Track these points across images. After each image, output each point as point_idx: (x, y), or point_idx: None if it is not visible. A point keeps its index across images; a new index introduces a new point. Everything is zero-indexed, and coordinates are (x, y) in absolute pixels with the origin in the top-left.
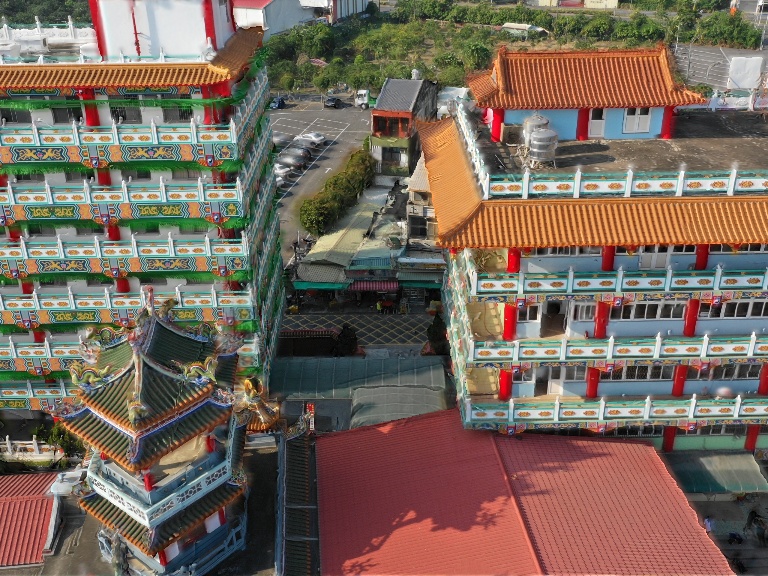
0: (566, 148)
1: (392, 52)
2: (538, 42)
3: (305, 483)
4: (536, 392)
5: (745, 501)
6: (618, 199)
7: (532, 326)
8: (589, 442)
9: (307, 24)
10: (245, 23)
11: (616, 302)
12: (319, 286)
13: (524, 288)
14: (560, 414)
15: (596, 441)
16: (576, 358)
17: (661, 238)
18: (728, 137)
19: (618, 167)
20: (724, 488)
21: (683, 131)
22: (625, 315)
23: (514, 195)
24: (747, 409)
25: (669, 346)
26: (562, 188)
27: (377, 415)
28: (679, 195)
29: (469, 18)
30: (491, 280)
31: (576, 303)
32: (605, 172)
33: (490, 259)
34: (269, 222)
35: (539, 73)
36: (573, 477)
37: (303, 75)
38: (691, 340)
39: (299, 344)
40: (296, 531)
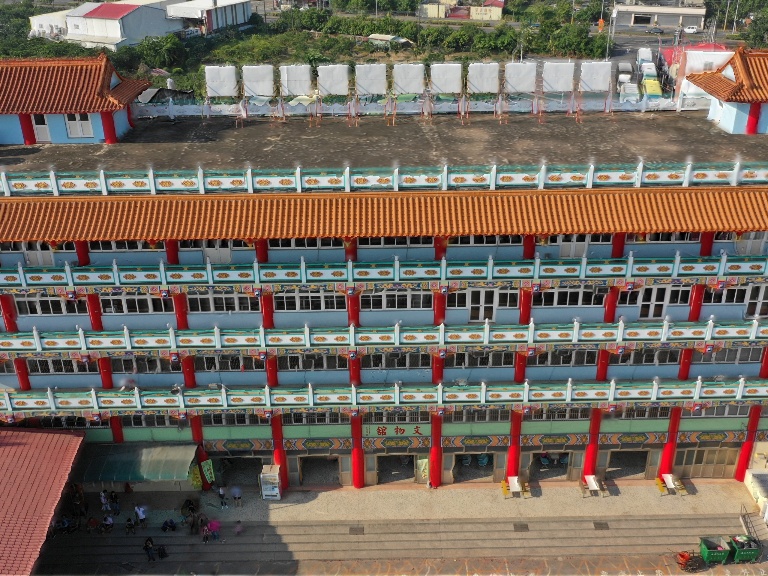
0: None
1: (242, 62)
2: (396, 53)
3: None
4: None
5: (210, 491)
6: None
7: None
8: (15, 432)
9: (175, 34)
10: (105, 33)
11: None
12: None
13: None
14: None
15: (24, 431)
16: None
17: None
18: (172, 142)
19: (10, 169)
20: (143, 477)
21: (142, 136)
22: (32, 310)
23: None
24: (148, 400)
25: (49, 339)
26: None
27: None
28: (7, 195)
29: (343, 29)
30: None
31: None
32: None
33: None
34: None
35: None
36: None
37: None
38: (69, 334)
39: None
40: None
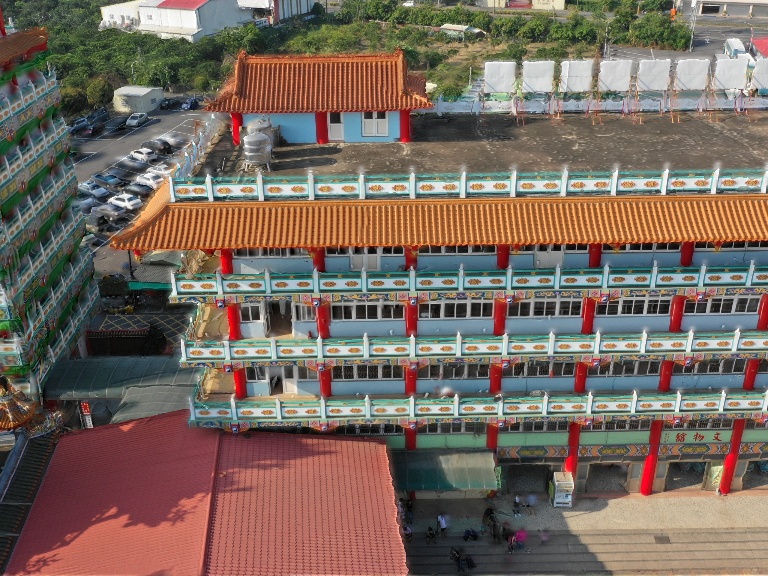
0: (299, 151)
1: (322, 53)
2: (473, 43)
3: (34, 480)
4: (273, 391)
5: (495, 498)
6: (301, 202)
7: (256, 326)
8: (320, 440)
9: (246, 25)
10: (180, 24)
11: (314, 303)
12: (153, 286)
13: (223, 289)
14: (283, 413)
15: (328, 439)
16: (287, 358)
17: (334, 240)
18: (467, 140)
19: (332, 170)
20: (452, 485)
21: (429, 134)
22: (347, 315)
23: (204, 198)
24: (466, 408)
25: (377, 346)
26: (246, 191)
27: (135, 414)
28: (362, 198)
29: (411, 19)
30: (189, 281)
31: (296, 304)
32: (315, 175)
33: (212, 260)
34: (60, 223)
35: (277, 77)
36: (285, 474)
37: (225, 76)
38: (399, 340)
39: (116, 344)
40: (3, 527)
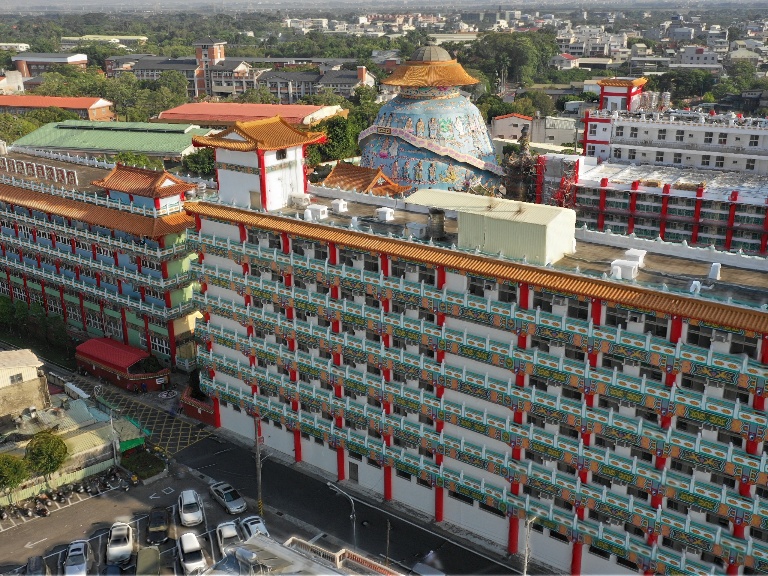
0: None
1: None
2: None
3: None
4: None
5: None
6: None
7: None
8: None
9: None
10: None
11: None
12: None
13: None
14: None
15: None
16: None
17: None
18: None
19: None
20: None
21: None
22: None
23: None
24: None
25: None
26: None
27: None
28: None
29: None
30: None
31: None
32: None
33: None
34: None
35: None
36: None
37: None
38: None
39: None
40: None
